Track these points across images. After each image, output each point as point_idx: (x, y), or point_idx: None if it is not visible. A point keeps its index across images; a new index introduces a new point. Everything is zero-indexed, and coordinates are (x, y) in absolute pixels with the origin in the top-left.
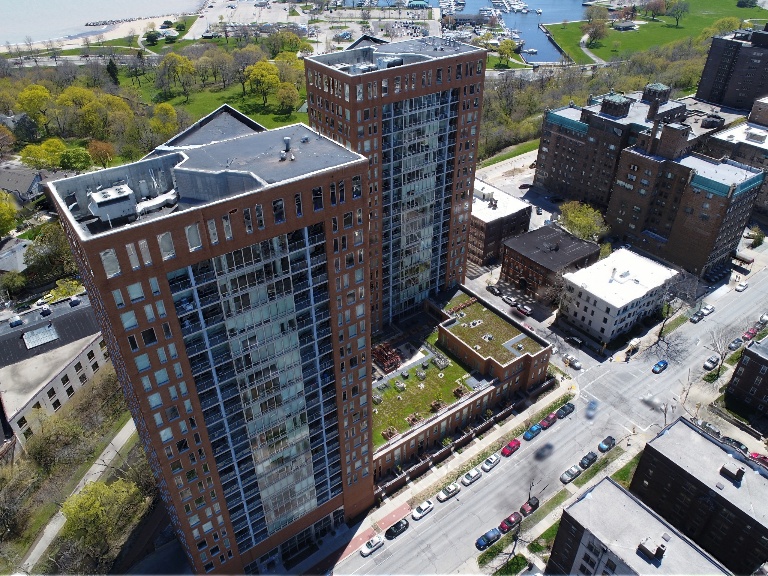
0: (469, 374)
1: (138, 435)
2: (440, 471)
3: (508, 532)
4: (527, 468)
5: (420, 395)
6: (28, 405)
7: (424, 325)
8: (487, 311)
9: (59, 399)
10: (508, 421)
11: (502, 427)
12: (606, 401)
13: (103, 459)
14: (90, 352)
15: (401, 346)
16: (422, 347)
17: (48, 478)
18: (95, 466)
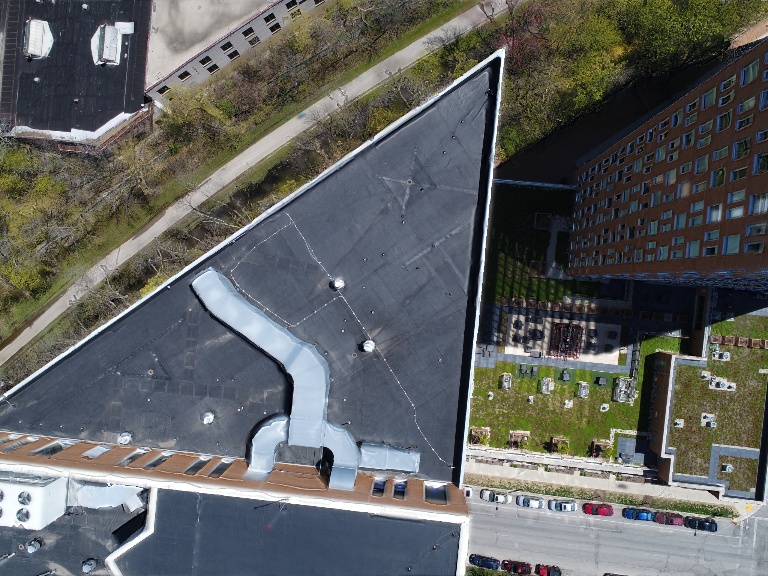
0: (636, 433)
1: (288, 151)
2: (510, 471)
3: (506, 571)
4: (589, 539)
5: (555, 415)
6: (172, 76)
7: (669, 313)
8: (763, 377)
9: (217, 63)
10: (631, 481)
11: (617, 482)
12: (759, 552)
13: (243, 160)
14: (269, 15)
15: (606, 325)
16: (628, 348)
17: (188, 146)
18: (233, 163)
